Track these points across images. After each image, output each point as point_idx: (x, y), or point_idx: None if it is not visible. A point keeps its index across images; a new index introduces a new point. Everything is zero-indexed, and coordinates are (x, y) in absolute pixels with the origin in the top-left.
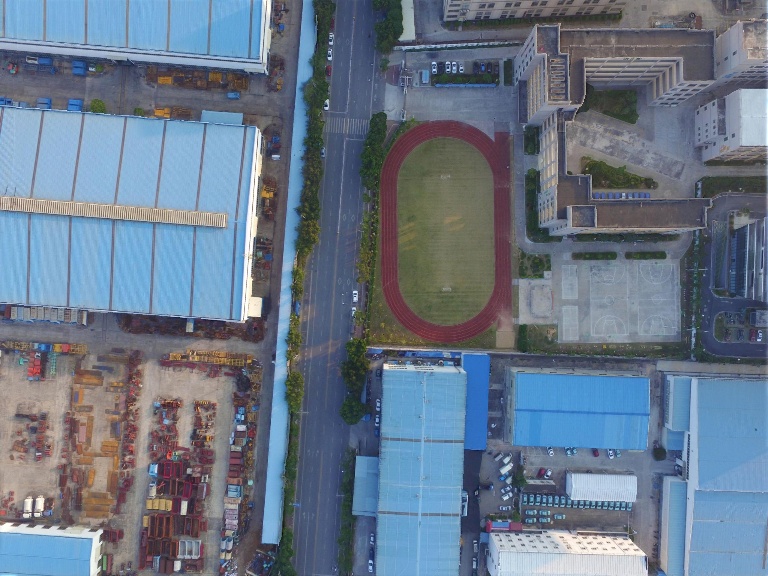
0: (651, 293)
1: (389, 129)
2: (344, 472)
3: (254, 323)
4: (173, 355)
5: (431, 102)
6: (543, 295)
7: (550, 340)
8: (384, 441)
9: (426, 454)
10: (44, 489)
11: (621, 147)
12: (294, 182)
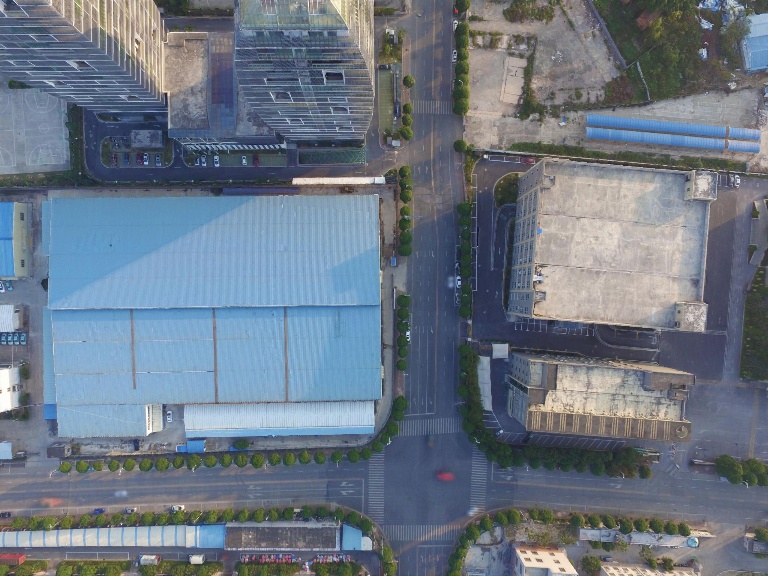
0: (38, 122)
1: None
2: None
3: None
4: None
5: None
6: None
7: None
8: None
9: None
10: None
11: None
12: None
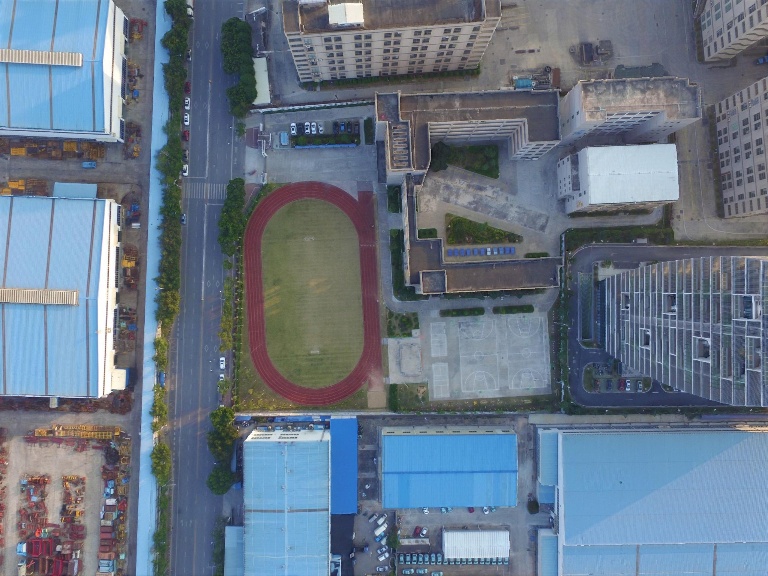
0: (520, 347)
1: (251, 192)
2: (214, 543)
3: (121, 395)
4: (38, 431)
5: (292, 164)
6: (412, 354)
7: (421, 398)
8: (247, 513)
9: (290, 524)
10: None
11: (485, 202)
12: (153, 252)
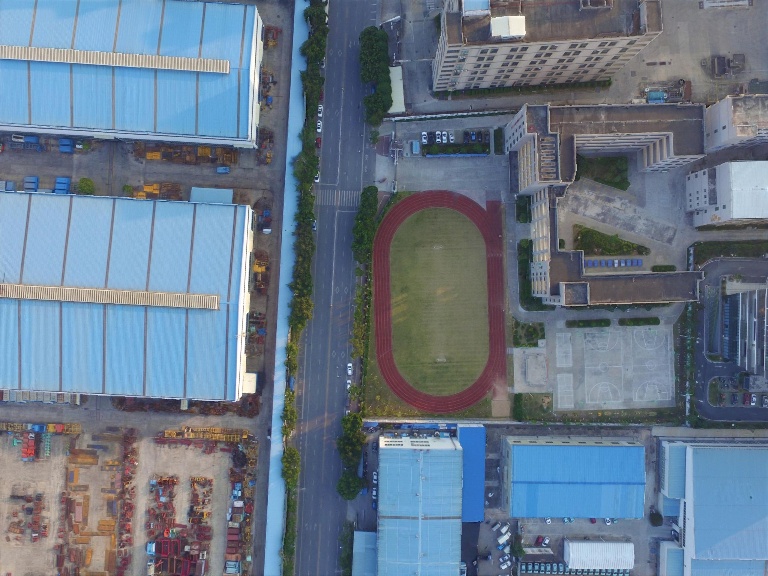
0: (645, 359)
1: (380, 200)
2: (342, 547)
3: (249, 398)
4: (168, 432)
5: (422, 172)
6: (538, 364)
7: (545, 408)
8: (381, 519)
9: (424, 531)
10: (41, 570)
11: (613, 214)
12: (286, 257)
